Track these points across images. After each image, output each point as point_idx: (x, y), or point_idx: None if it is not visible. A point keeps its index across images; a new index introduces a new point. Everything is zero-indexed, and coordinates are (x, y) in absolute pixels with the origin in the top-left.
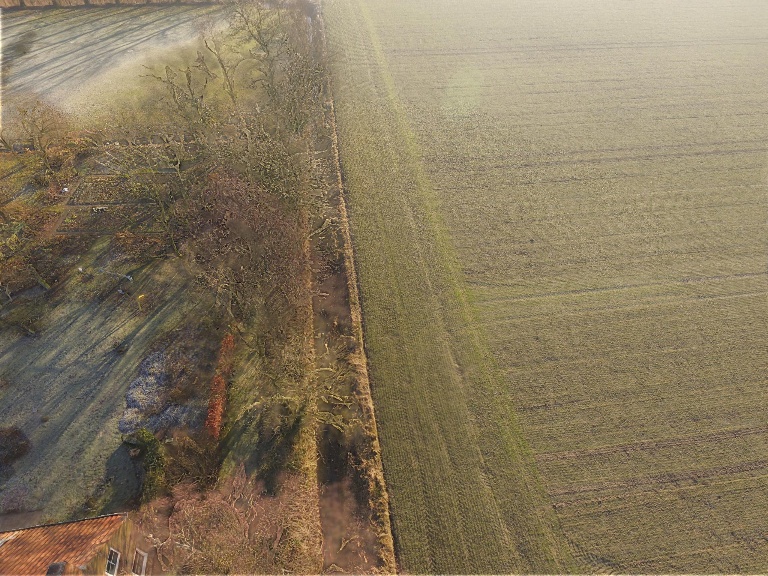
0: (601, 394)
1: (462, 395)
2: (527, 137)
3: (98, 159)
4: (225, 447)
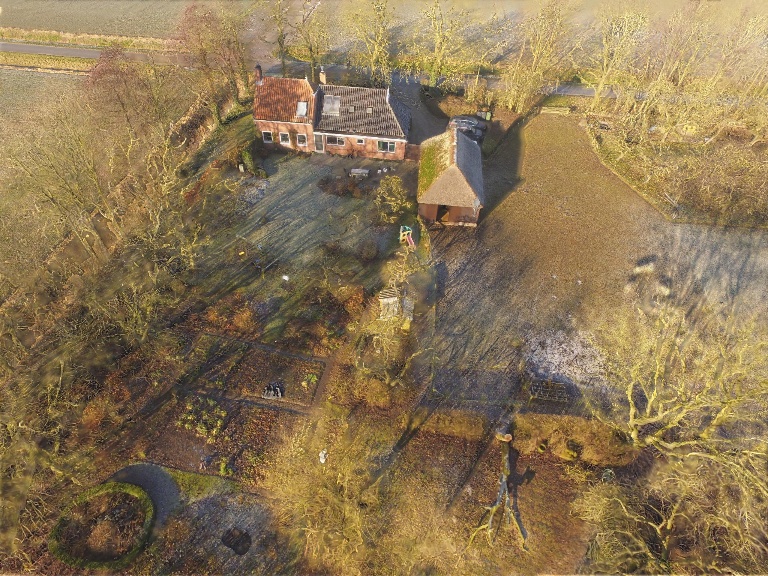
0: (6, 150)
1: None
2: None
3: (271, 568)
4: None
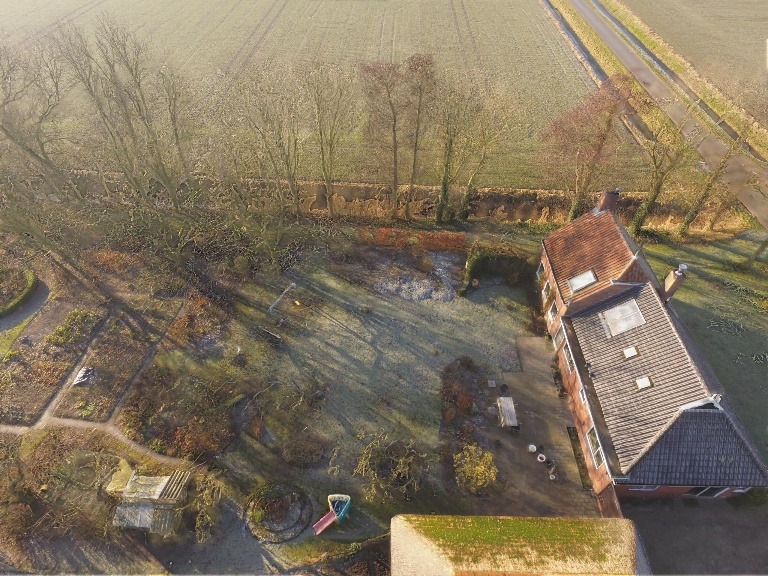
0: None
1: (441, 152)
2: (190, 78)
3: None
4: (469, 246)
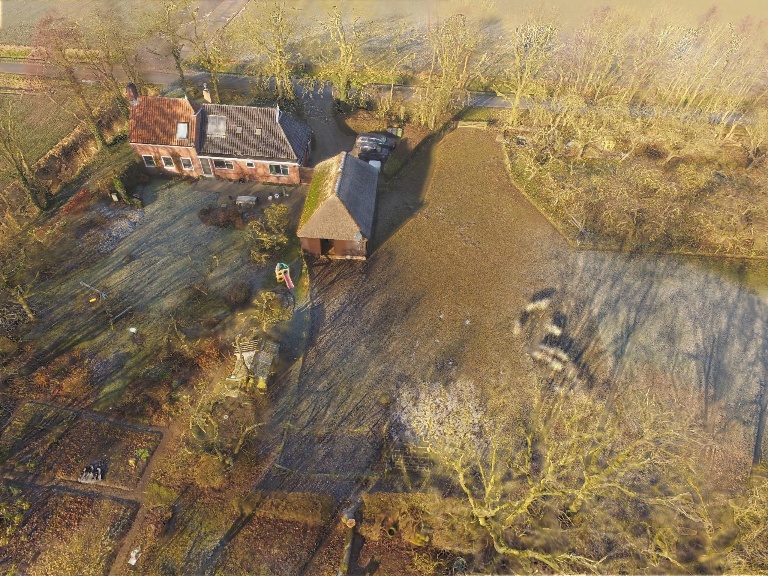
0: None
1: None
2: None
3: None
4: None
